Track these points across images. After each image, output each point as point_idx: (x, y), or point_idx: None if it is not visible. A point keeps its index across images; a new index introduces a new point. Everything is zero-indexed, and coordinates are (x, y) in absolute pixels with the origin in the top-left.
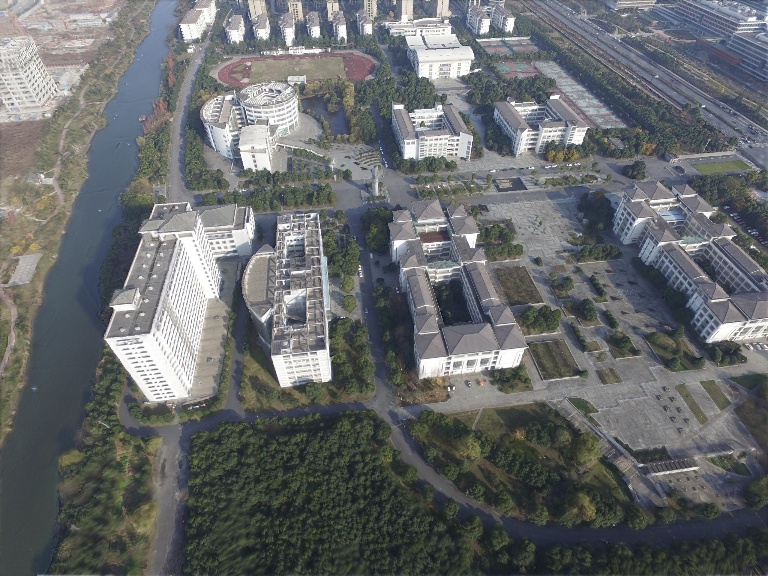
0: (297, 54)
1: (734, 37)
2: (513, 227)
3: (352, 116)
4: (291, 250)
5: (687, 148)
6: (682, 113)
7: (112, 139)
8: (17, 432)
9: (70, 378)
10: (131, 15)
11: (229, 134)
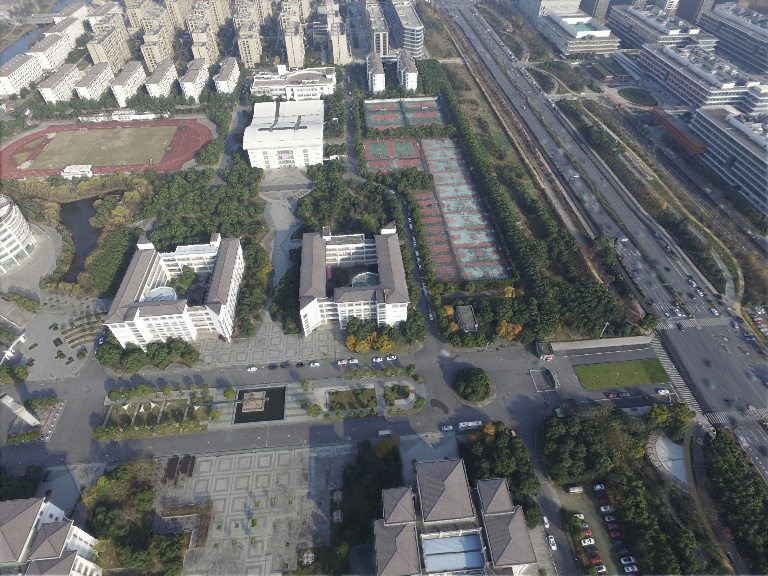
0: (124, 120)
1: (697, 115)
2: (207, 525)
3: None
4: None
5: (572, 333)
6: (587, 255)
7: None
8: None
9: None
10: None
11: None
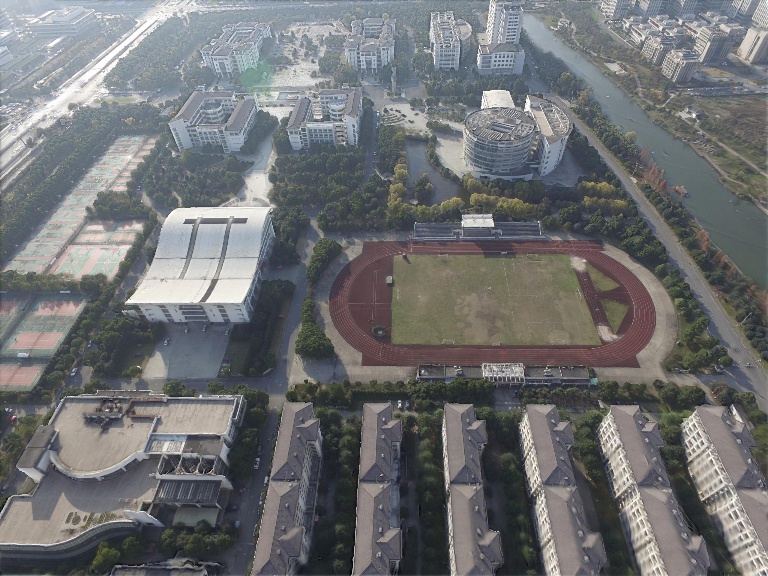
0: None
1: None
2: None
3: (401, 139)
4: None
5: None
6: None
7: (688, 167)
8: (551, 36)
9: (544, 43)
10: None
11: None
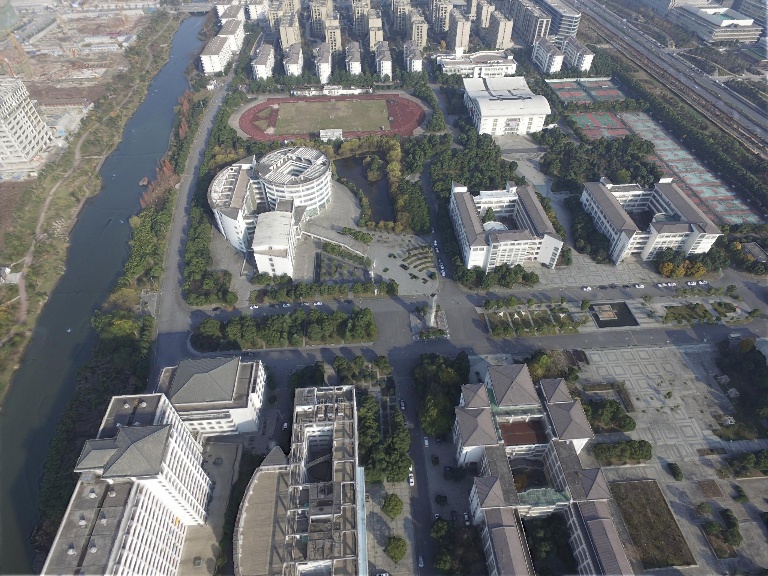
0: (333, 95)
1: None
2: (628, 397)
3: (399, 195)
4: (313, 440)
5: None
6: None
7: (104, 211)
8: None
9: None
10: (151, 38)
11: (242, 222)
